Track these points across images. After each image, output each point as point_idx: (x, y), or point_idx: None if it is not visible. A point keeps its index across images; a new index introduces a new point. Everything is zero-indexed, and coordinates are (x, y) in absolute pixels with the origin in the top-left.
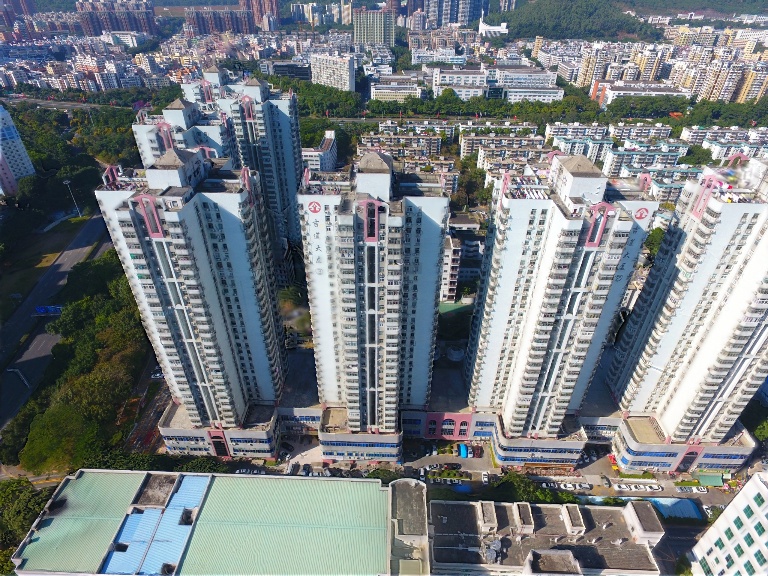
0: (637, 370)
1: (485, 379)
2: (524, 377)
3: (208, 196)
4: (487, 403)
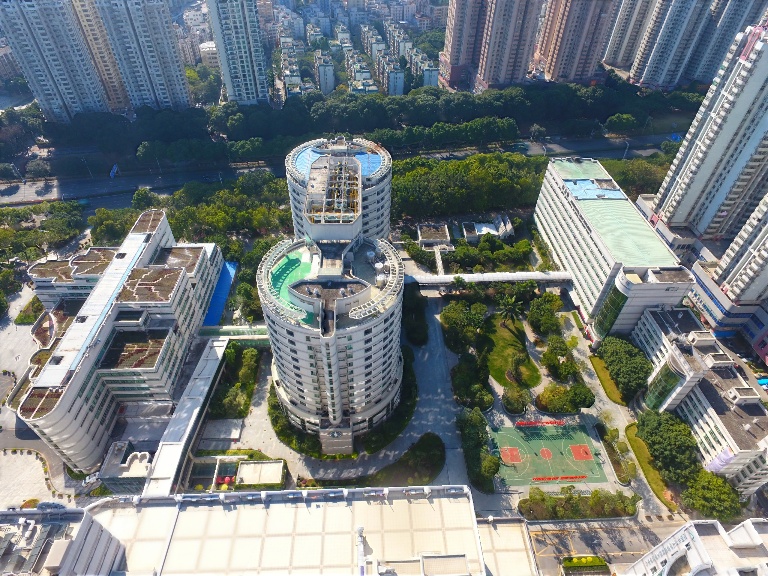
0: None
1: None
2: None
3: None
4: None
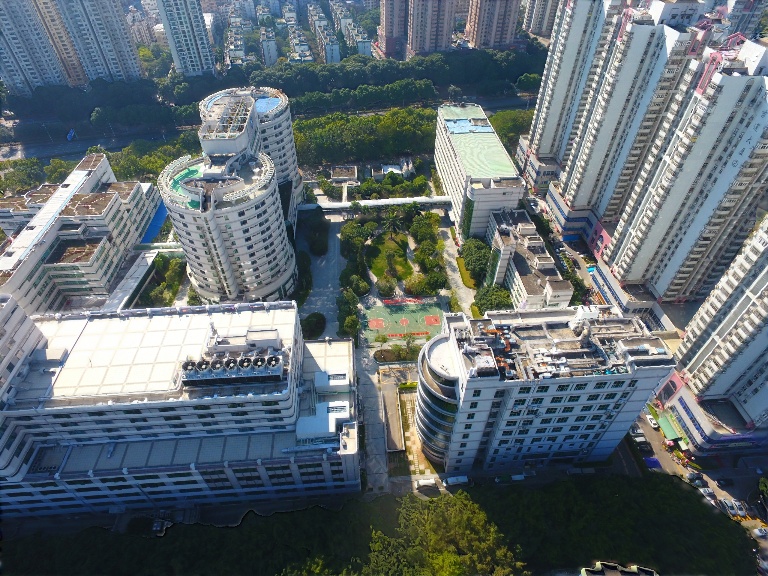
0: None
1: None
2: None
3: None
4: None
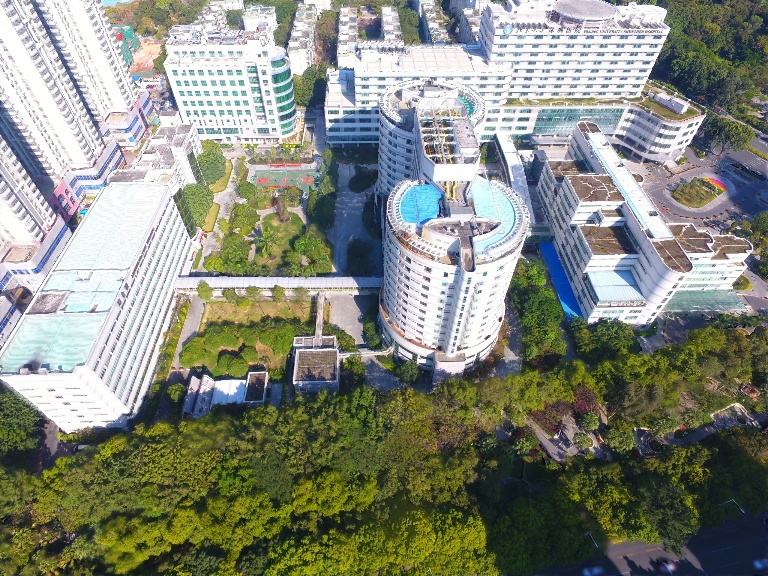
0: (80, 85)
1: (42, 147)
2: (61, 110)
3: None
4: (59, 167)
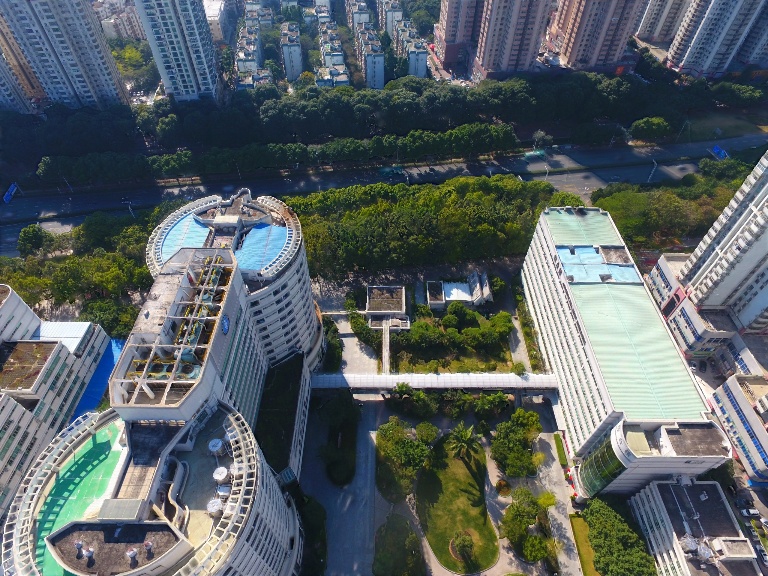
0: None
1: None
2: None
3: None
4: None
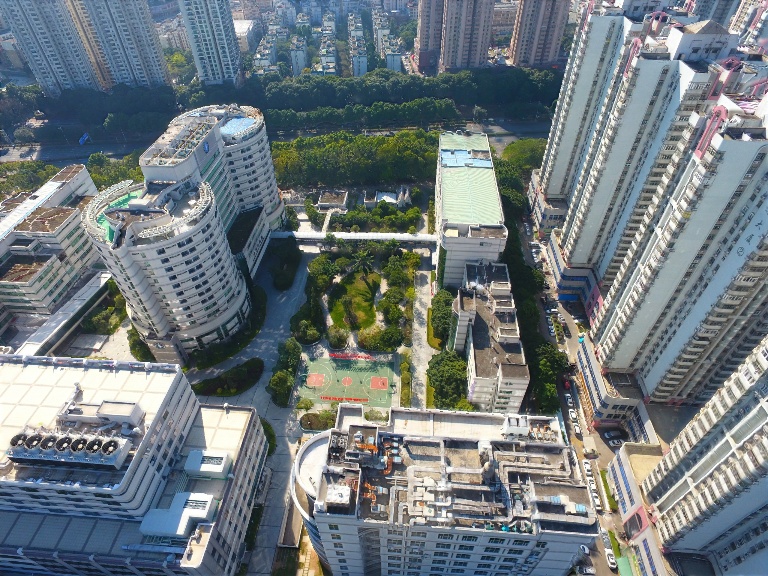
0: None
1: None
2: None
3: (624, 20)
4: None
